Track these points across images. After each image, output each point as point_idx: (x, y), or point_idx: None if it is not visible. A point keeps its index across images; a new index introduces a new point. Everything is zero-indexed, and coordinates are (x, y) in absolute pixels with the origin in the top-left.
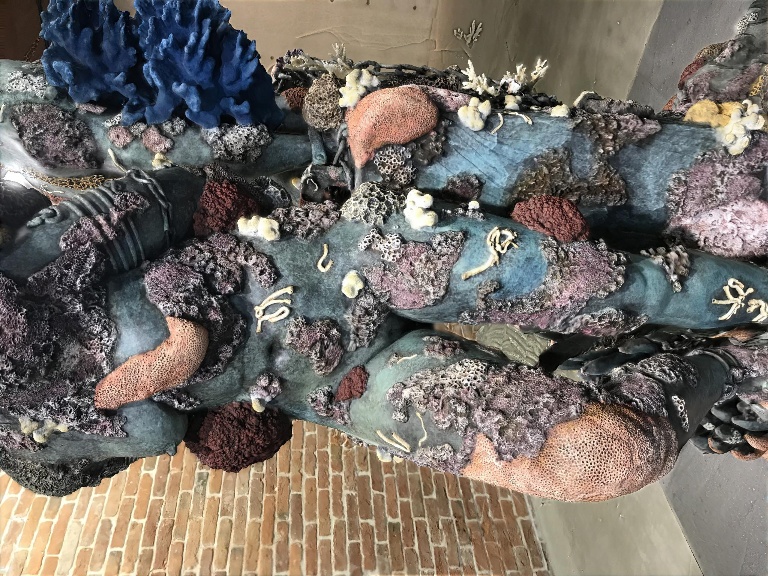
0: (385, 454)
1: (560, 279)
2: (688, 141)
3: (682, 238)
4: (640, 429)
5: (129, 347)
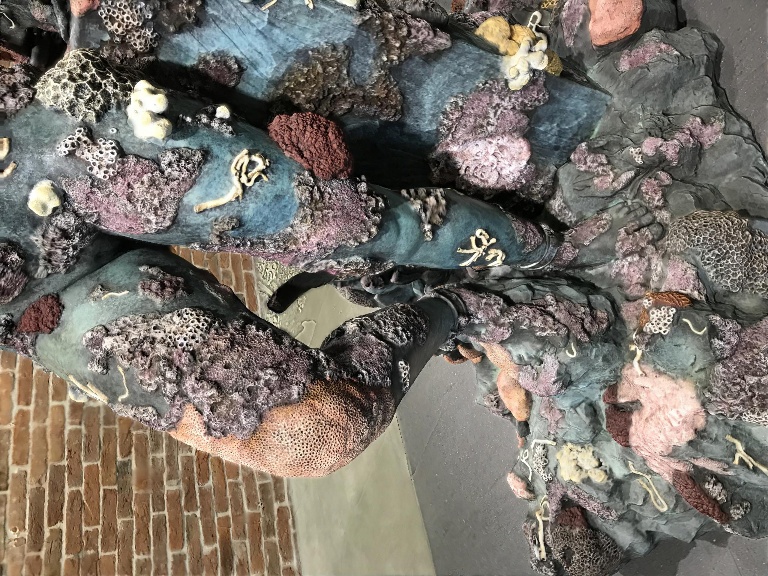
0: (80, 395)
1: (310, 223)
2: (474, 65)
3: (446, 164)
4: (360, 409)
5: None
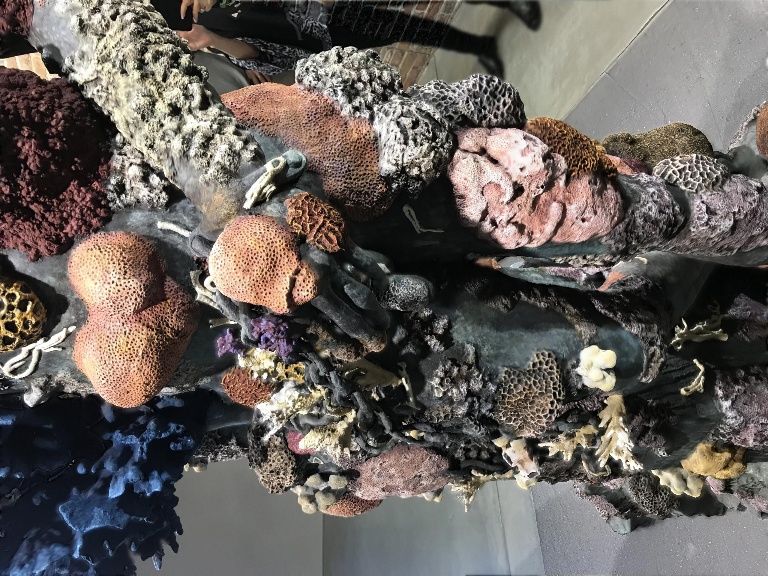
0: None
1: None
2: None
3: None
4: None
5: None
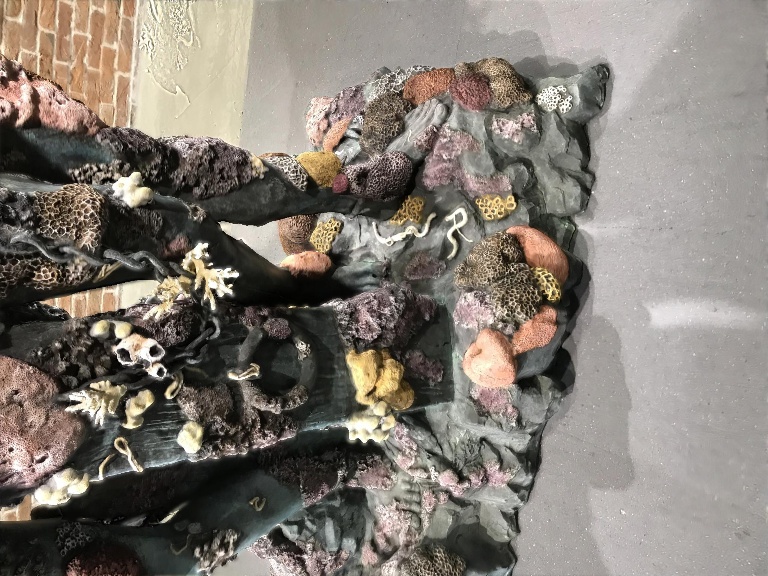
0: None
1: None
2: None
3: None
4: None
5: None
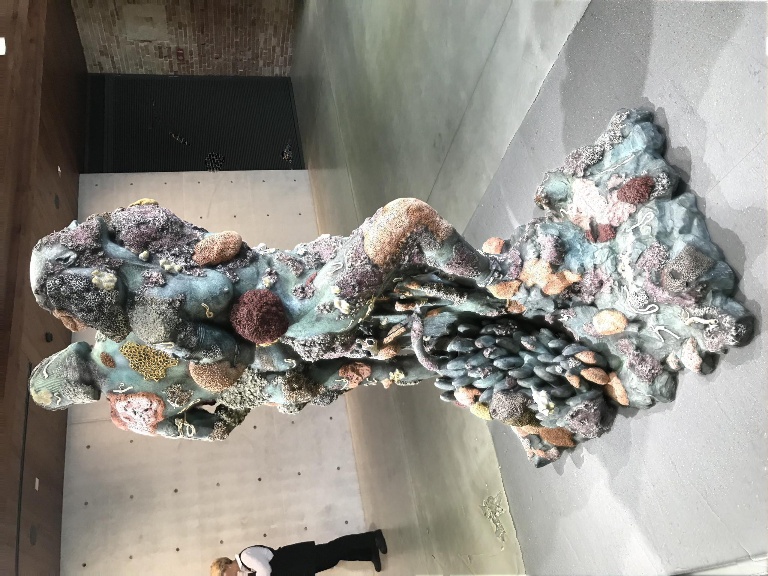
0: None
1: None
2: None
3: None
4: None
5: (210, 234)
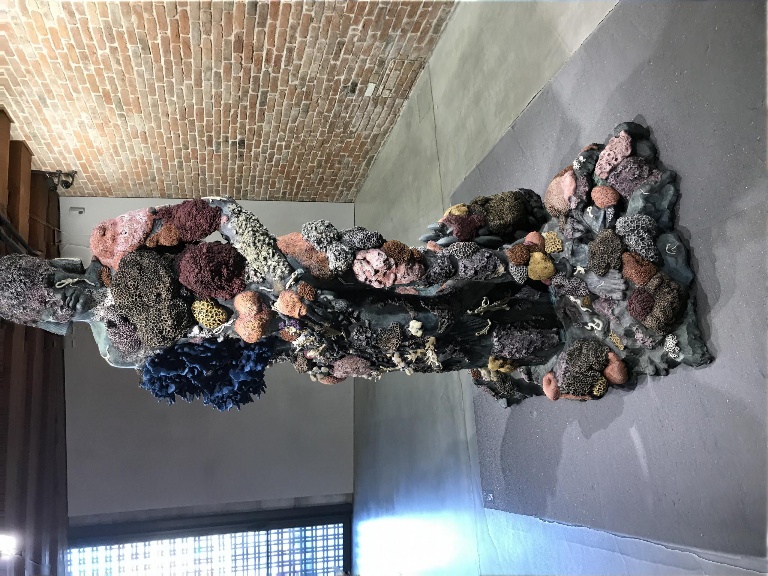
0: None
1: None
2: None
3: None
4: None
5: None
